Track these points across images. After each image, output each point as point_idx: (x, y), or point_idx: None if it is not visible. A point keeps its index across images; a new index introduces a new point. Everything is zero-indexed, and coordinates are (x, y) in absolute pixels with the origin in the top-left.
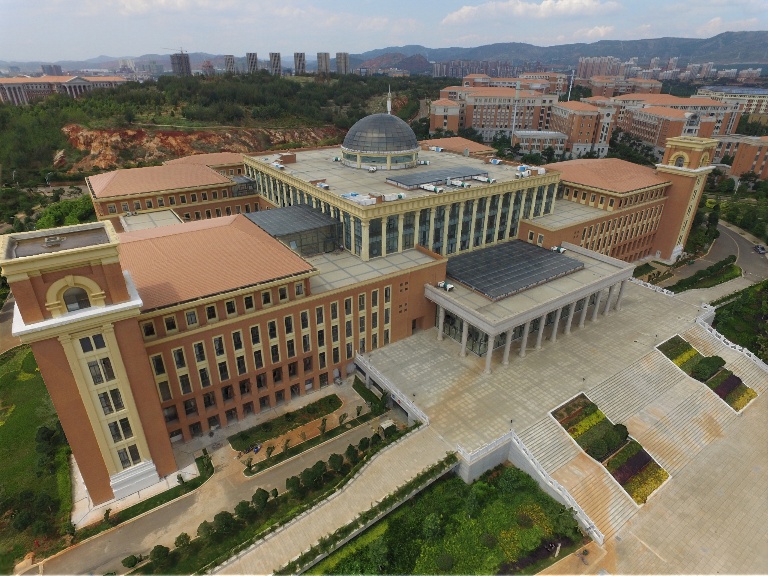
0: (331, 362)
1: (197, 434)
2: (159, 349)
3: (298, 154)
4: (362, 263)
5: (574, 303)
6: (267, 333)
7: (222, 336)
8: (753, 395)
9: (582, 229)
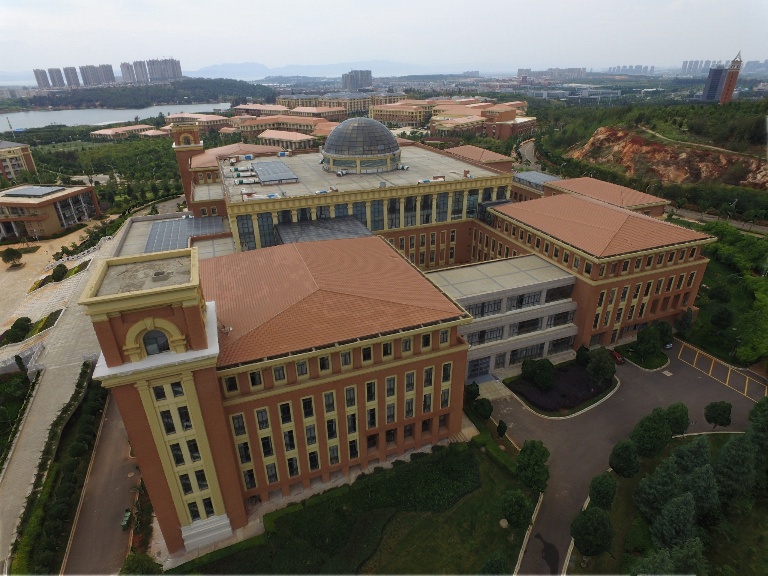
0: None
1: None
2: None
3: None
4: None
5: None
6: None
7: None
8: None
9: None
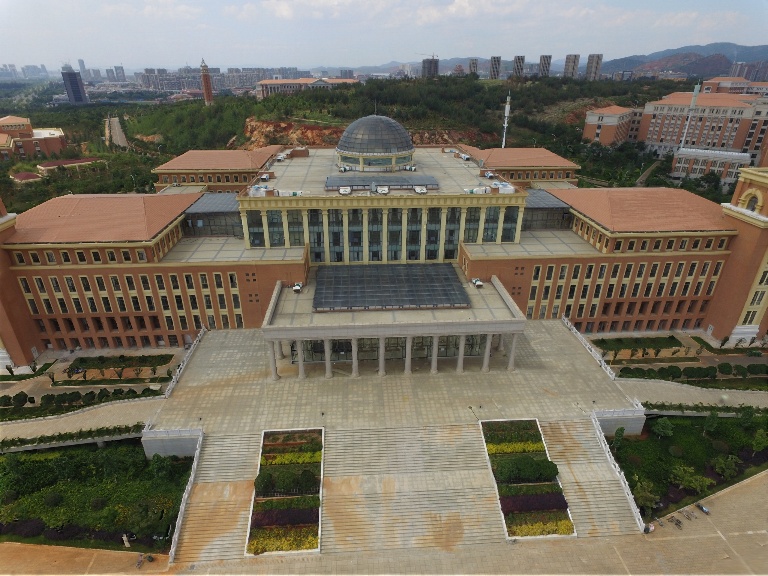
0: (179, 327)
1: (66, 348)
2: (23, 274)
3: (331, 150)
4: (242, 249)
5: (407, 339)
6: (111, 285)
7: (72, 277)
8: (560, 529)
9: (531, 266)
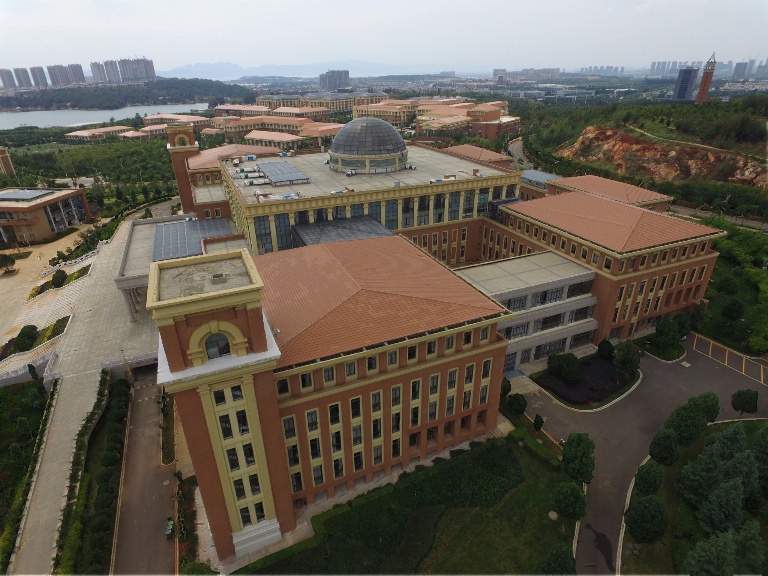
0: None
1: None
2: None
3: (425, 152)
4: None
5: None
6: None
7: None
8: None
9: None
